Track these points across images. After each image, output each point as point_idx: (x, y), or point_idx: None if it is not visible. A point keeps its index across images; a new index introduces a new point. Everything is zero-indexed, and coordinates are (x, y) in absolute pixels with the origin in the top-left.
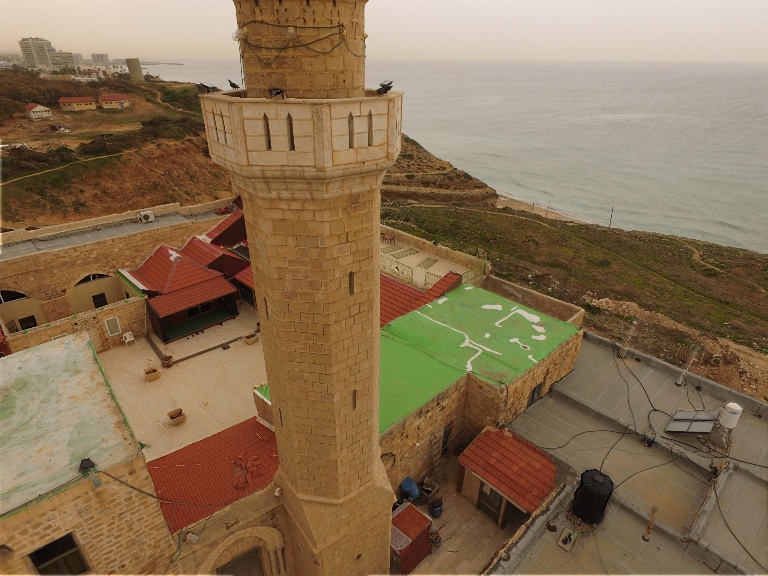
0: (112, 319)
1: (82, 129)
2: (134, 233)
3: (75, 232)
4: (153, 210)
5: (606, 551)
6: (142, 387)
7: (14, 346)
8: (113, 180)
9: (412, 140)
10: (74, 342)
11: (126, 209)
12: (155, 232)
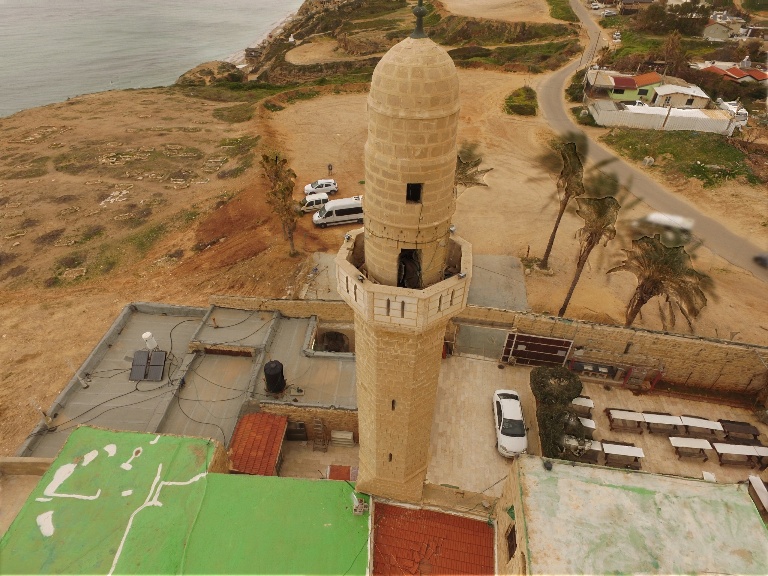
0: None
1: None
2: None
3: None
4: None
5: (292, 377)
6: None
7: None
8: None
9: None
10: None
11: None
12: None
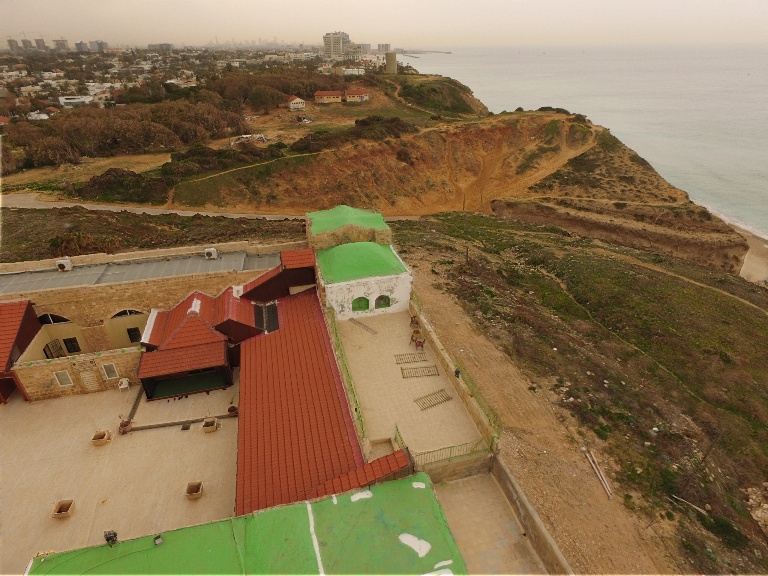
0: (109, 365)
1: (320, 121)
2: (168, 278)
3: (147, 260)
4: (221, 247)
5: None
6: (85, 450)
7: (21, 374)
8: (305, 177)
9: (641, 158)
10: None
11: (308, 205)
12: (189, 279)
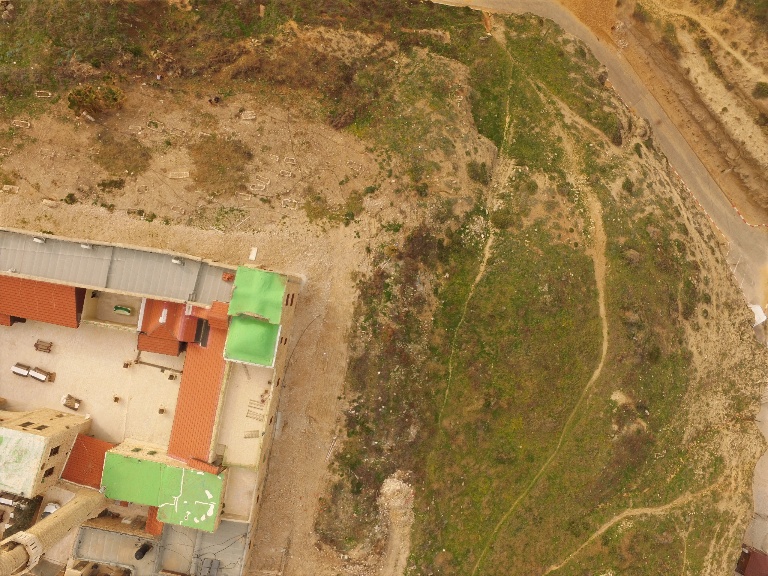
0: None
1: None
2: (147, 297)
3: None
4: None
5: None
6: (122, 367)
7: None
8: None
9: None
10: (42, 442)
11: None
12: None
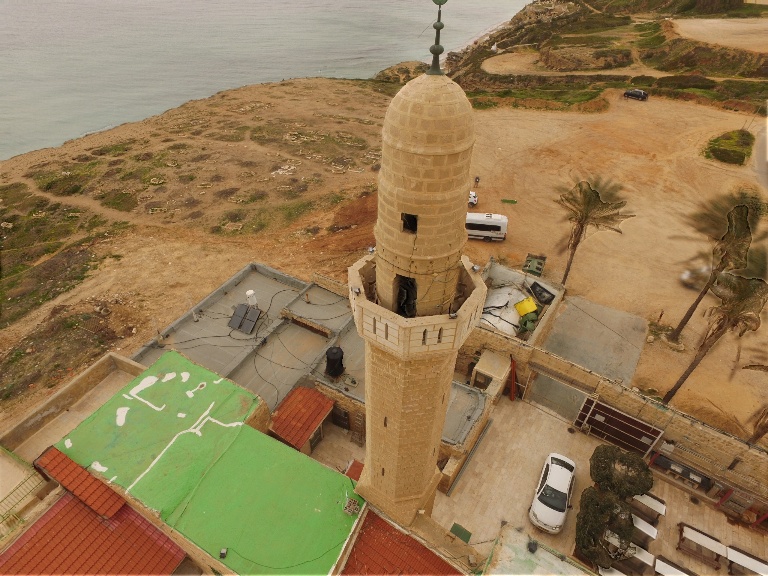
0: None
1: None
2: None
3: None
4: None
5: (353, 367)
6: None
7: None
8: None
9: None
10: None
11: None
12: None
